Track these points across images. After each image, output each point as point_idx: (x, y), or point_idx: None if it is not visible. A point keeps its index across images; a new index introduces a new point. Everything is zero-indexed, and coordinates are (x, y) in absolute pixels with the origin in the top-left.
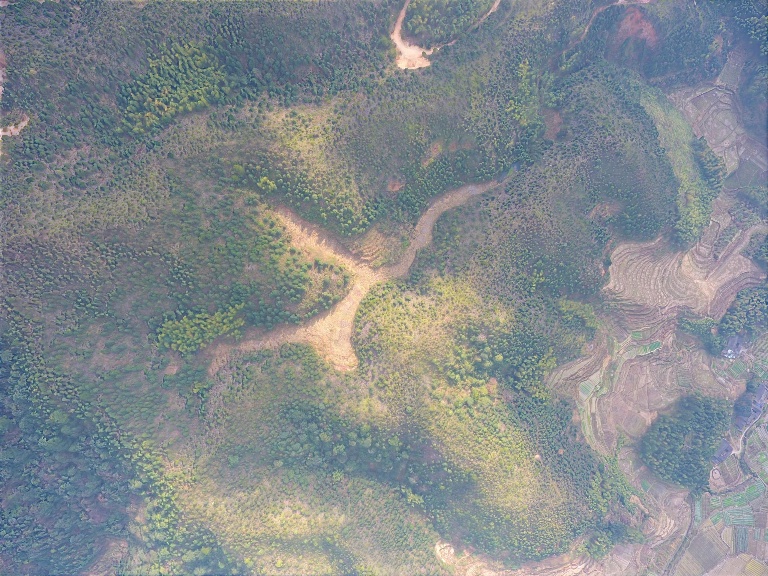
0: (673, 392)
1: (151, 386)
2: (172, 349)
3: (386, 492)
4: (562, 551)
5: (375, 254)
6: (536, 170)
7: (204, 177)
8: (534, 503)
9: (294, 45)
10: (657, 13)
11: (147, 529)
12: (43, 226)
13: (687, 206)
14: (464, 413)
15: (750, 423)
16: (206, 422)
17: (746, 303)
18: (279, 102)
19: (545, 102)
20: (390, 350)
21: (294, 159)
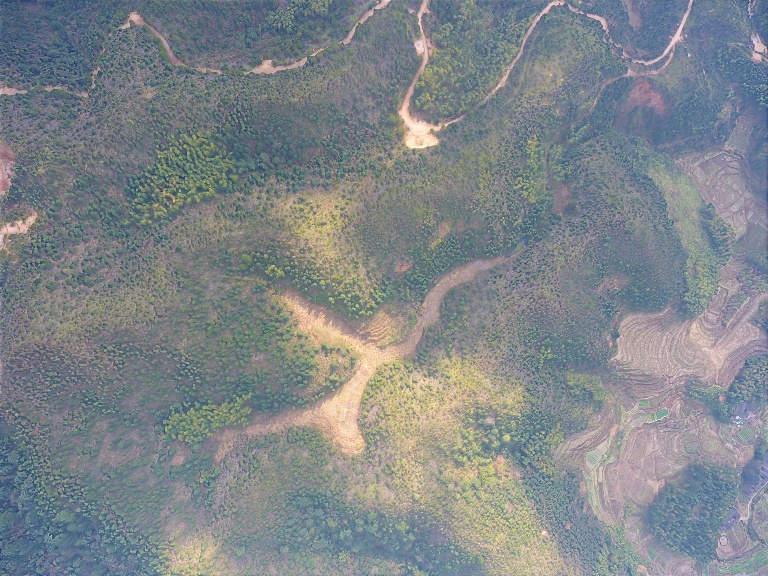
0: (680, 459)
1: (157, 479)
2: (179, 438)
3: (392, 569)
4: None
5: (382, 334)
6: (544, 247)
7: (212, 268)
8: None
9: (302, 129)
10: (666, 84)
11: None
12: (51, 331)
13: (696, 277)
14: (471, 496)
15: (758, 489)
16: (212, 513)
17: (755, 372)
18: (287, 187)
19: (553, 177)
20: (397, 436)
21: (302, 248)
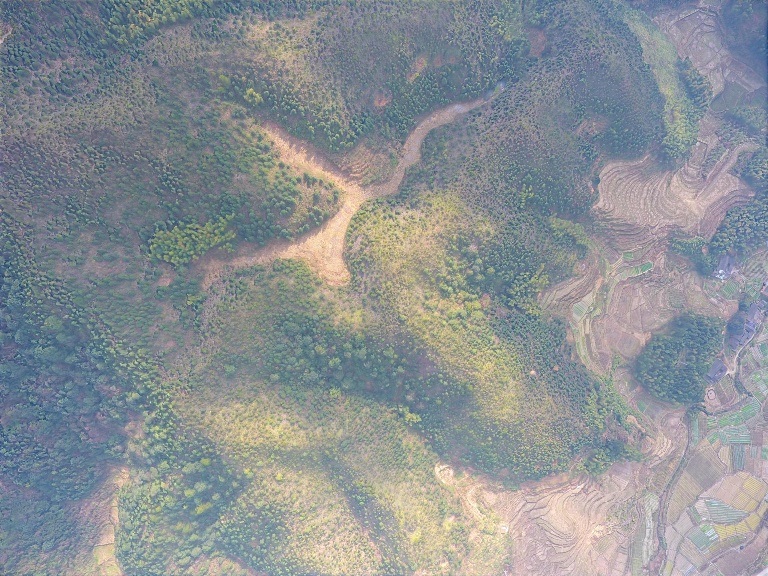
0: (666, 313)
1: (145, 296)
2: (164, 262)
3: (384, 411)
4: (561, 469)
5: (364, 171)
6: (522, 85)
7: (190, 88)
8: (531, 416)
9: None
10: None
11: (146, 443)
12: (30, 127)
13: (673, 123)
14: (458, 324)
15: (744, 343)
16: (201, 333)
17: (735, 220)
18: (263, 16)
19: (529, 19)
20: (382, 260)
21: (279, 69)
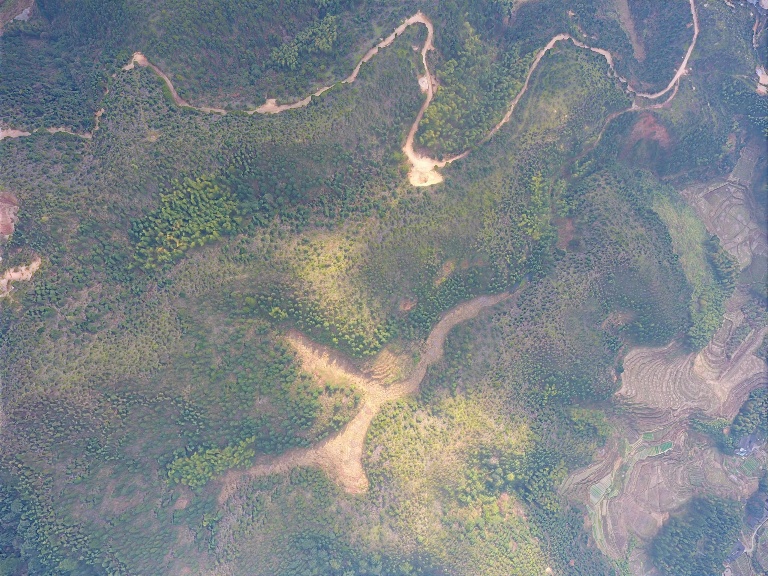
0: (685, 492)
1: (161, 525)
2: None
3: None
4: None
5: (386, 373)
6: (548, 283)
7: (215, 311)
8: None
9: (306, 170)
10: (671, 118)
11: None
12: (54, 381)
13: (700, 311)
14: (475, 536)
15: (762, 521)
16: (216, 556)
17: (759, 405)
18: (291, 228)
19: (558, 212)
20: (401, 478)
21: (306, 290)
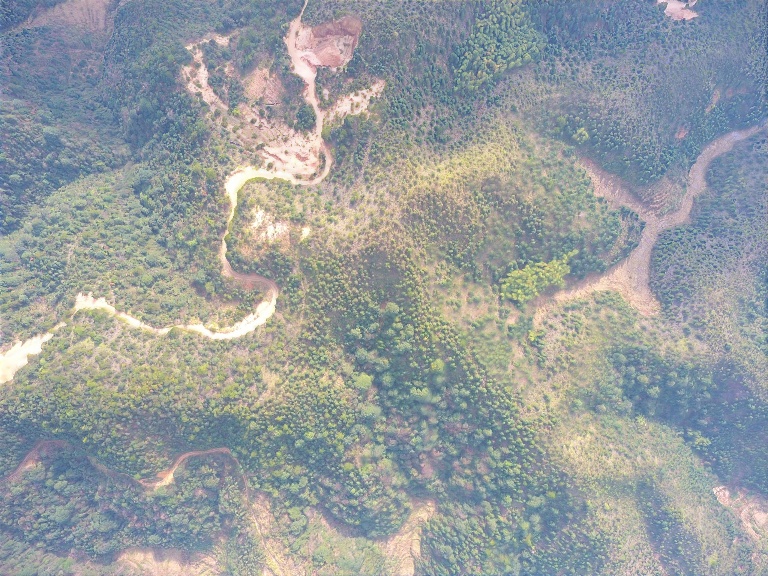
0: None
1: (503, 334)
2: (507, 300)
3: (675, 436)
4: None
5: (663, 201)
6: None
7: (534, 130)
8: None
9: (589, 1)
10: None
11: (489, 478)
12: (434, 177)
13: None
14: None
15: None
16: (547, 368)
17: None
18: (580, 56)
19: None
20: (704, 289)
21: (612, 108)
